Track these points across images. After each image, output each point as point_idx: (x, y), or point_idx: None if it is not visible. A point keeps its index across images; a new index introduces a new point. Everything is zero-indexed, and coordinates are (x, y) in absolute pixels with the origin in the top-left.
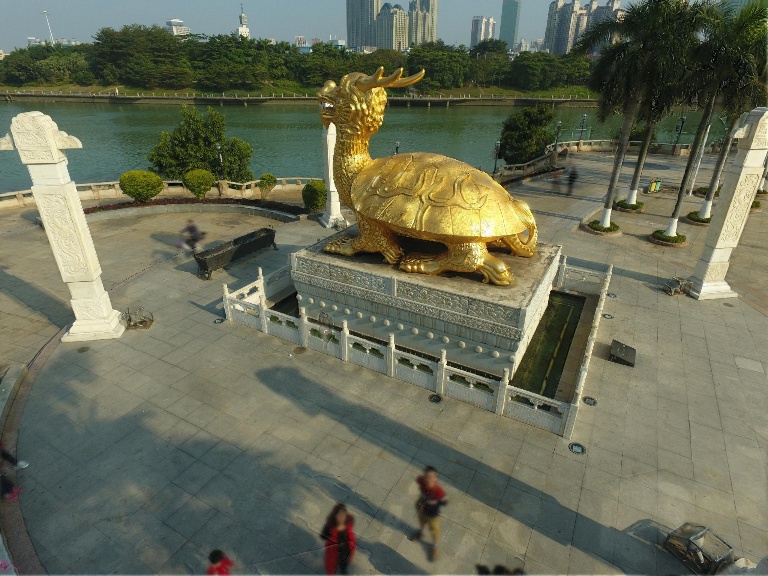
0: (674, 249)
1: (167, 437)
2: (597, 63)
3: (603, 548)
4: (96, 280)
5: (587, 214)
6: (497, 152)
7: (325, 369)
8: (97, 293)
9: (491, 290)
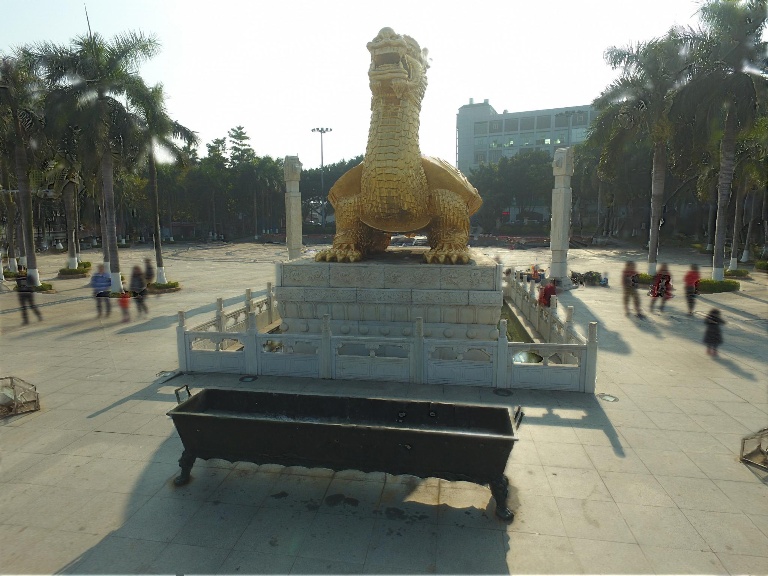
0: (186, 290)
1: (759, 359)
2: (55, 101)
3: (567, 295)
4: None
5: None
6: None
7: None
8: None
9: None
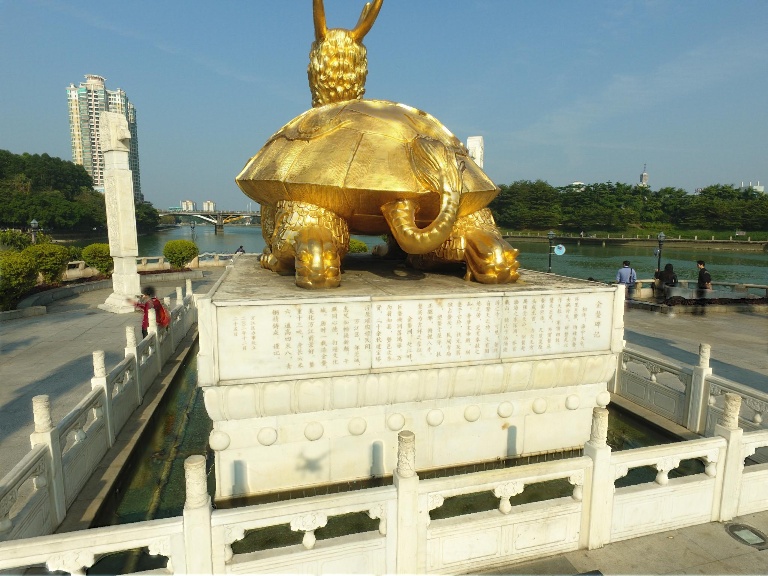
0: None
1: None
2: None
3: None
4: (126, 258)
5: None
6: None
7: None
8: (124, 270)
9: (270, 287)
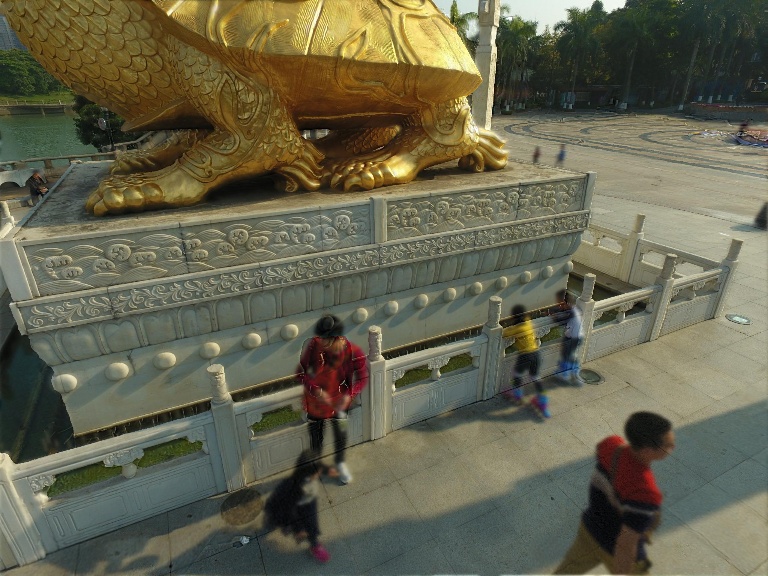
0: None
1: None
2: None
3: None
4: None
5: None
6: (107, 119)
7: (382, 488)
8: None
9: (508, 174)
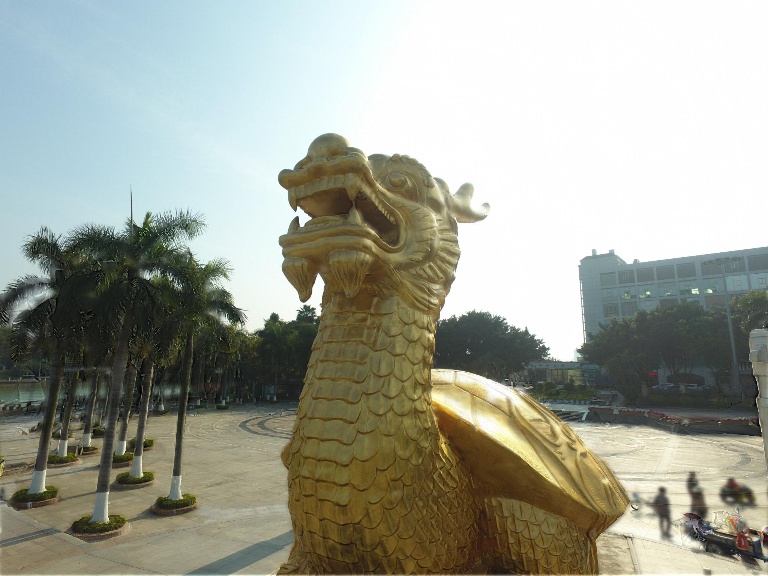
0: (201, 511)
1: None
2: (68, 285)
3: None
4: None
5: (37, 522)
6: None
7: None
8: None
9: None
